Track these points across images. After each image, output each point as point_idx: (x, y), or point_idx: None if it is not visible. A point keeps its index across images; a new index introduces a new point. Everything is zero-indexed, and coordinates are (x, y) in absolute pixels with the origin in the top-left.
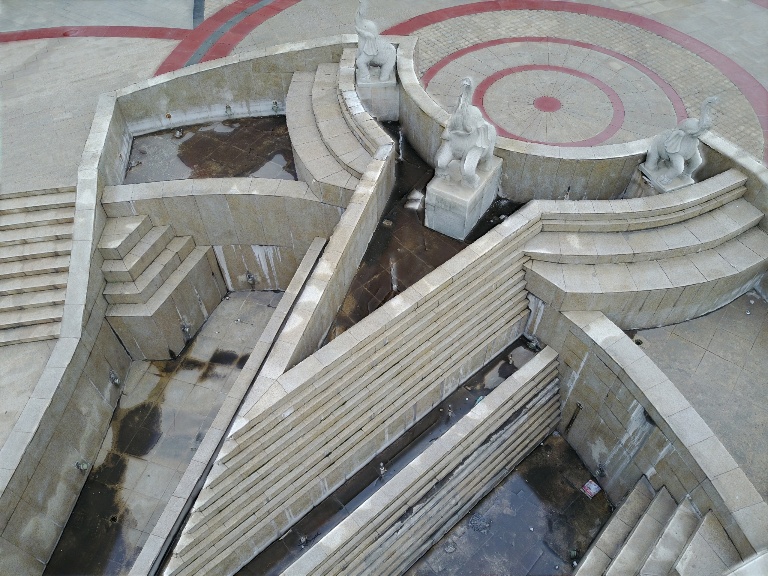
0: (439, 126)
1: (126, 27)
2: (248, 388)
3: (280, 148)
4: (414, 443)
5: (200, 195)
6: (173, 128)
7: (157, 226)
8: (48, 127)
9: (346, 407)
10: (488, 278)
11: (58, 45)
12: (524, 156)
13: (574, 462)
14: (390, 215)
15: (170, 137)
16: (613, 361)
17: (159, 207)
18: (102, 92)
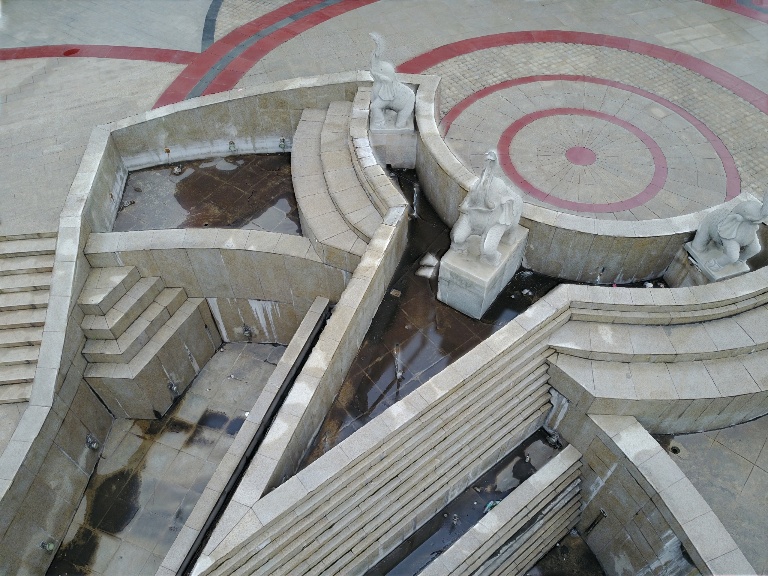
0: (458, 186)
1: (130, 48)
2: (230, 478)
3: (285, 191)
4: (413, 556)
5: (192, 248)
6: (172, 163)
7: (145, 277)
8: (36, 161)
9: (333, 531)
10: (506, 376)
11: (57, 66)
12: (553, 228)
13: (593, 569)
14: (399, 283)
15: (168, 173)
16: (647, 482)
17: (147, 258)
18: (98, 122)
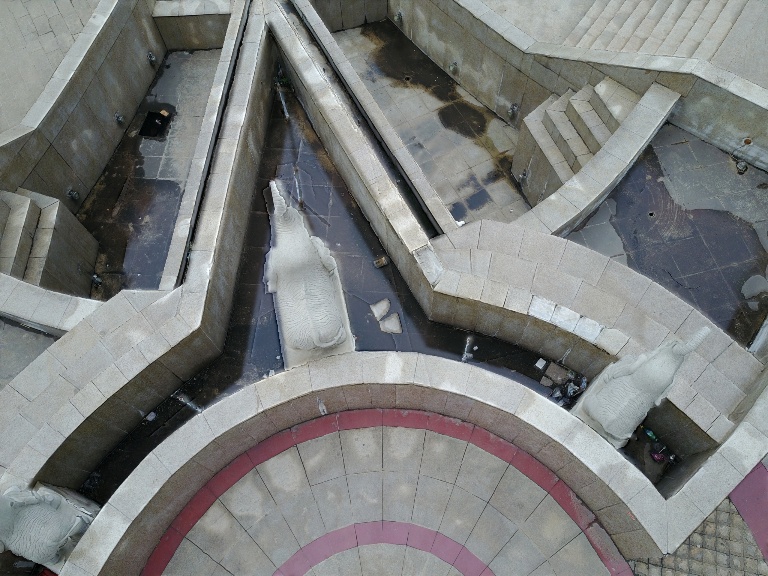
0: None
1: None
2: None
3: None
4: None
5: None
6: None
7: None
8: None
9: None
10: None
11: None
12: None
13: None
14: (390, 276)
15: None
16: None
17: None
18: None
